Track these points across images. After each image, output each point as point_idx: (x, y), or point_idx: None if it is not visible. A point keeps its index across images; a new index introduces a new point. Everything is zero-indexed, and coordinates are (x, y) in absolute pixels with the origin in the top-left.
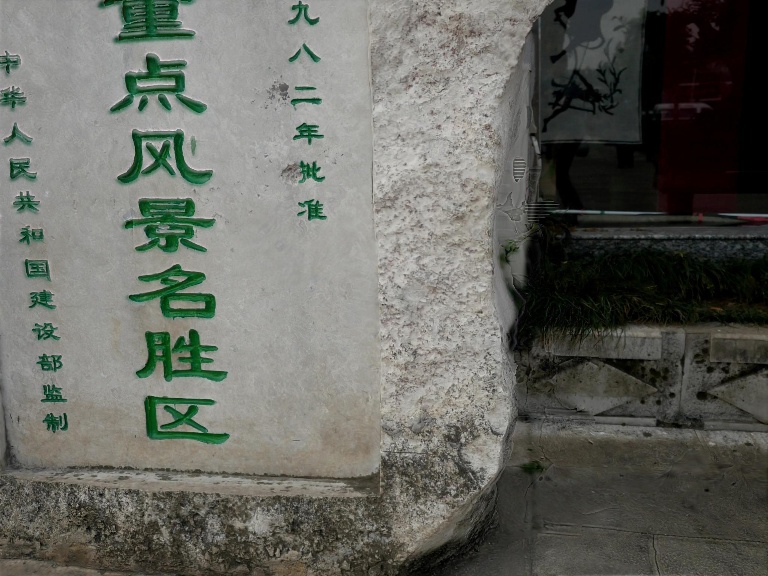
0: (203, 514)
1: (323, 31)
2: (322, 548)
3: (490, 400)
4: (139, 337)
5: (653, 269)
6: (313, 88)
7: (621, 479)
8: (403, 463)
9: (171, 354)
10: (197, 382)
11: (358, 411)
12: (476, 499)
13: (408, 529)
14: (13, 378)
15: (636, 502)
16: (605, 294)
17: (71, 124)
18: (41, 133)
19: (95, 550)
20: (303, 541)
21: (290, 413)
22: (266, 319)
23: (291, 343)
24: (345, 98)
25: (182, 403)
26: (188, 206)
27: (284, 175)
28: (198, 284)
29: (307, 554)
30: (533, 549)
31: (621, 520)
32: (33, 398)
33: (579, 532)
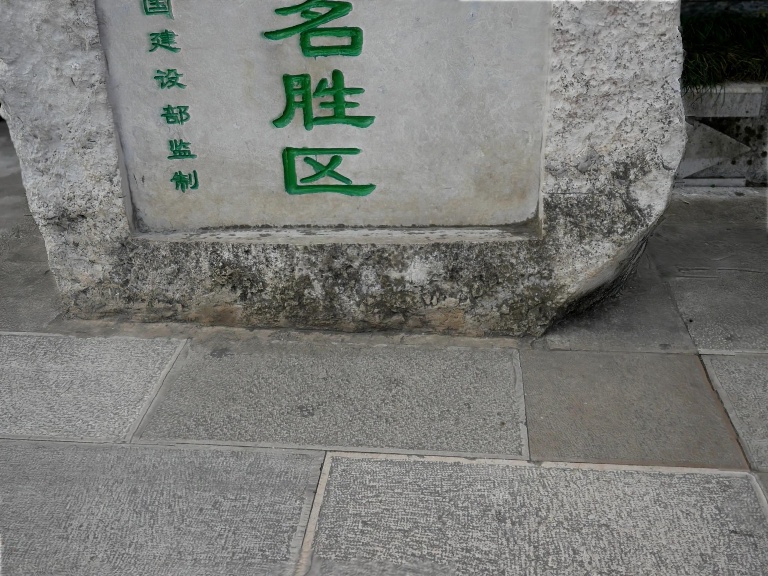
0: (356, 266)
1: None
2: (481, 293)
3: (665, 132)
4: (276, 81)
5: (734, 28)
6: None
7: (729, 232)
8: (567, 204)
9: (312, 99)
10: (341, 129)
11: (516, 153)
12: (643, 236)
13: (571, 270)
14: (135, 134)
15: (752, 250)
16: (697, 51)
17: None
18: None
19: (241, 308)
20: (461, 288)
21: (443, 159)
22: (420, 54)
23: (447, 81)
24: None
25: (324, 154)
26: None
27: None
28: (344, 16)
29: (465, 300)
30: (676, 290)
31: (755, 262)
32: (159, 155)
33: (716, 274)
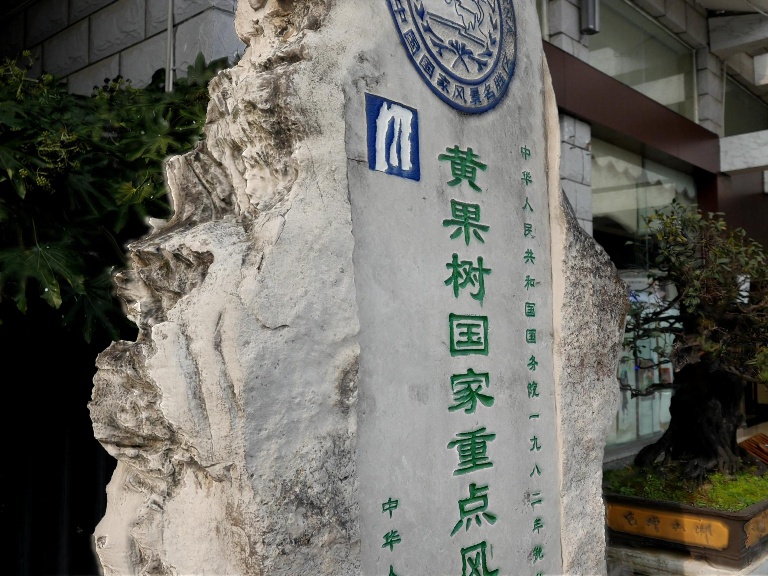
0: None
1: (541, 454)
2: None
3: None
4: None
5: None
6: (539, 494)
7: None
8: None
9: None
10: None
11: None
12: None
13: None
14: None
15: None
16: None
17: (426, 555)
18: (408, 570)
19: None
20: None
21: None
22: None
23: None
24: (550, 497)
25: None
26: None
27: (527, 560)
28: None
29: None
30: None
31: None
32: None
33: None
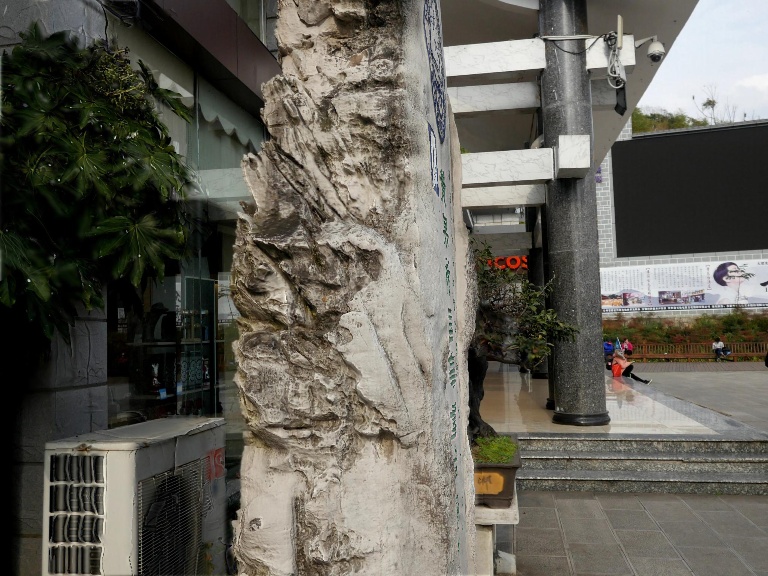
0: None
1: (459, 422)
2: None
3: None
4: None
5: None
6: None
7: None
8: None
9: None
10: None
11: None
12: None
13: None
14: None
15: None
16: None
17: None
18: None
19: None
20: None
21: None
22: None
23: None
24: None
25: None
26: (458, 543)
27: None
28: None
29: None
30: None
31: None
32: None
33: None
